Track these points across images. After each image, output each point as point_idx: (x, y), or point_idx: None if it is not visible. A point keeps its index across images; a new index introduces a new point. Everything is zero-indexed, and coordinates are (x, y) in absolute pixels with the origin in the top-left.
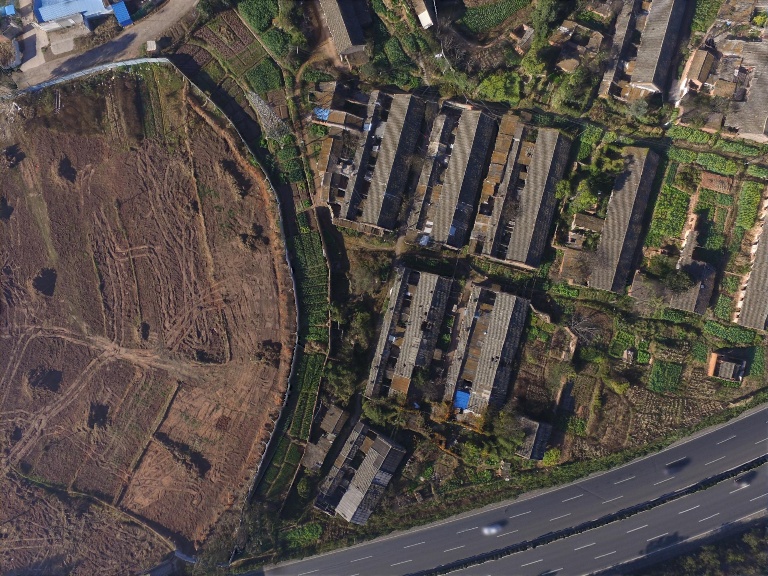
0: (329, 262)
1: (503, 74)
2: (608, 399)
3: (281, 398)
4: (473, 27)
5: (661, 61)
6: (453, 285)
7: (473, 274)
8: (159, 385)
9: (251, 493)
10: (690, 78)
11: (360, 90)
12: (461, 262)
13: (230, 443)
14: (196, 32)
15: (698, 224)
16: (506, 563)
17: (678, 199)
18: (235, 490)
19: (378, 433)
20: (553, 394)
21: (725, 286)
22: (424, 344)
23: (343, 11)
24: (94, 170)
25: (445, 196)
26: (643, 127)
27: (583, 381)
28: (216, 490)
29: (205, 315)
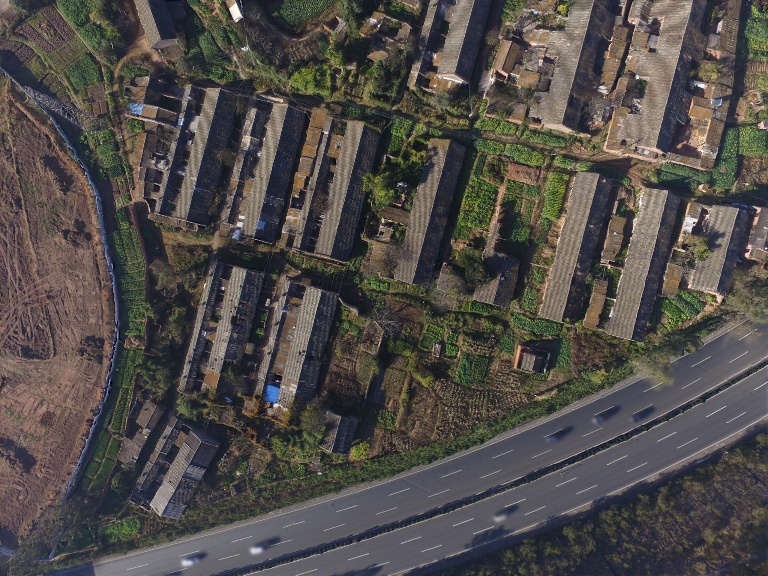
0: (146, 257)
1: (314, 67)
2: (417, 392)
3: (102, 393)
4: (290, 20)
5: (465, 52)
6: (267, 279)
7: (287, 268)
8: None
9: (73, 488)
10: (495, 69)
11: (177, 84)
12: (276, 256)
13: (55, 439)
14: (17, 28)
15: (504, 216)
16: (332, 557)
17: (485, 191)
18: (57, 485)
19: (193, 428)
20: (362, 388)
21: (531, 278)
22: (234, 338)
23: (153, 5)
24: None
25: (255, 190)
26: (450, 119)
27: (393, 374)
28: (42, 485)
29: (30, 311)
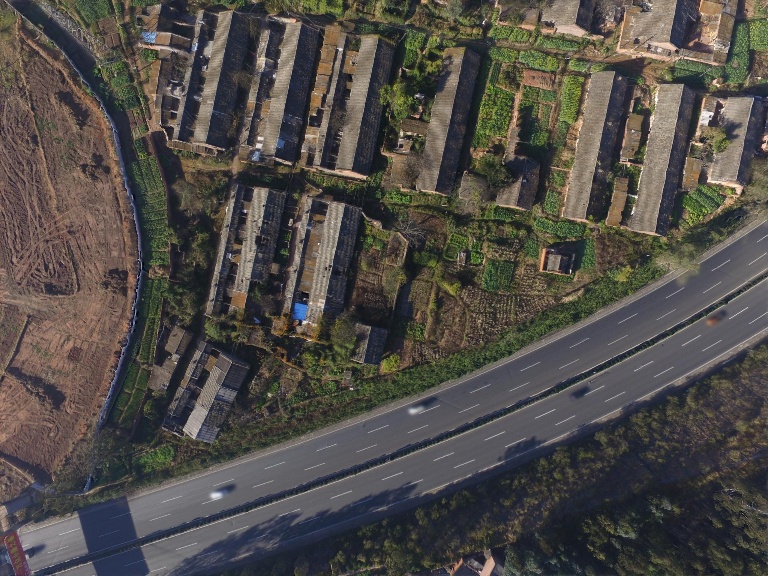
0: (167, 185)
1: None
2: (444, 302)
3: (128, 324)
4: None
5: None
6: (288, 200)
7: (308, 188)
8: (10, 321)
9: (104, 421)
10: None
11: (189, 12)
12: (296, 177)
13: (83, 374)
14: None
15: (522, 121)
16: (366, 478)
17: (502, 98)
18: (88, 419)
19: (222, 351)
20: (390, 300)
21: (552, 181)
22: (259, 258)
23: None
24: None
25: (273, 110)
26: (463, 28)
27: (420, 286)
28: (72, 421)
29: (51, 248)
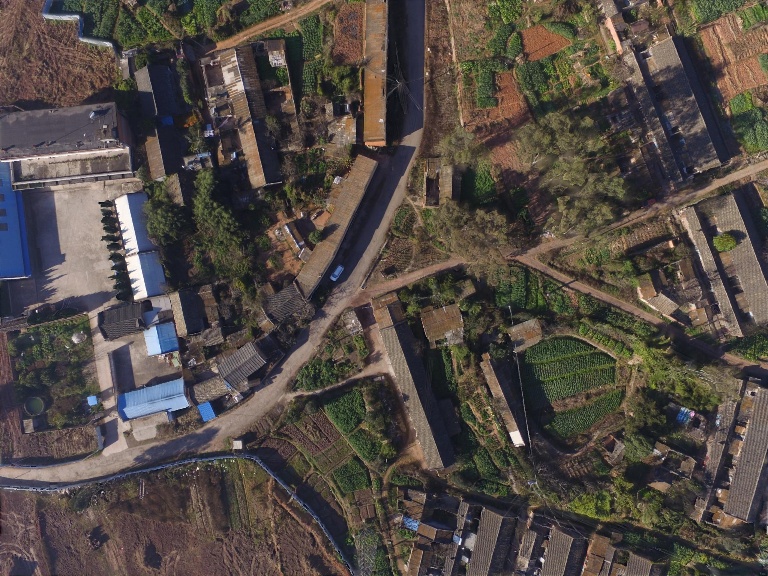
0: None
1: (594, 492)
2: None
3: None
4: (562, 432)
5: (755, 497)
6: None
7: None
8: None
9: None
10: None
11: (448, 494)
12: None
13: None
14: (282, 428)
15: None
16: None
17: None
18: None
19: None
20: None
21: None
22: None
23: (434, 431)
24: (179, 557)
25: None
26: (735, 555)
27: None
28: None
29: None
